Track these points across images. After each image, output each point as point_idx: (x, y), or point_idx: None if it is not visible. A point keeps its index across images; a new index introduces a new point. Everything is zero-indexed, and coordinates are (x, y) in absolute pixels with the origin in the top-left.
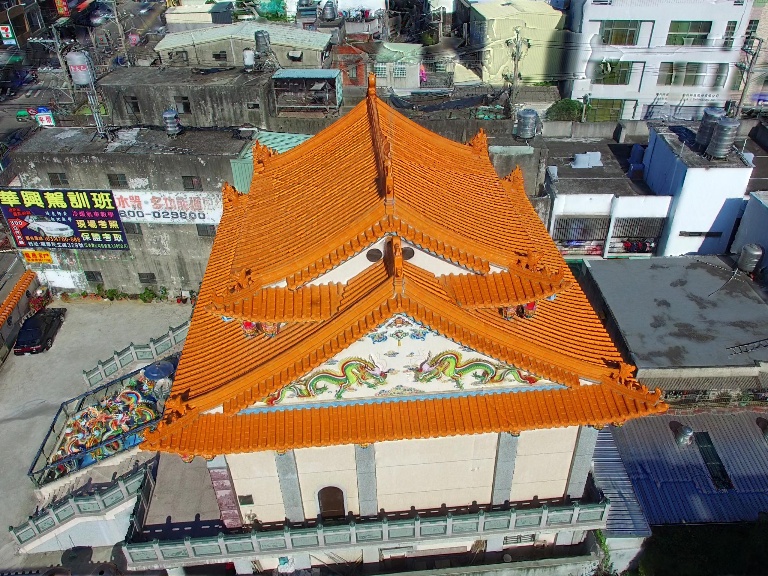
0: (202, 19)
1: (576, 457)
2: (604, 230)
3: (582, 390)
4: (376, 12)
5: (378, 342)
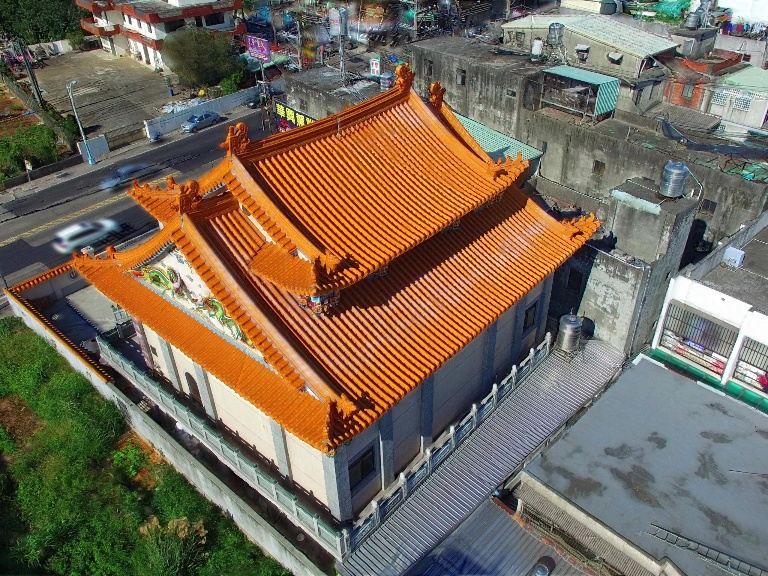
0: (592, 8)
1: (324, 470)
2: (729, 345)
3: (308, 398)
4: (766, 30)
5: (180, 262)
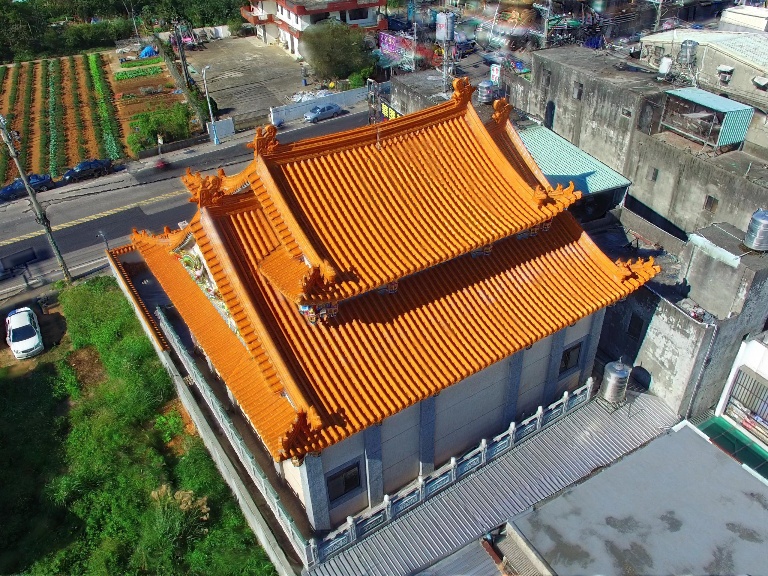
0: (756, 24)
1: None
2: None
3: (285, 404)
4: None
5: None
